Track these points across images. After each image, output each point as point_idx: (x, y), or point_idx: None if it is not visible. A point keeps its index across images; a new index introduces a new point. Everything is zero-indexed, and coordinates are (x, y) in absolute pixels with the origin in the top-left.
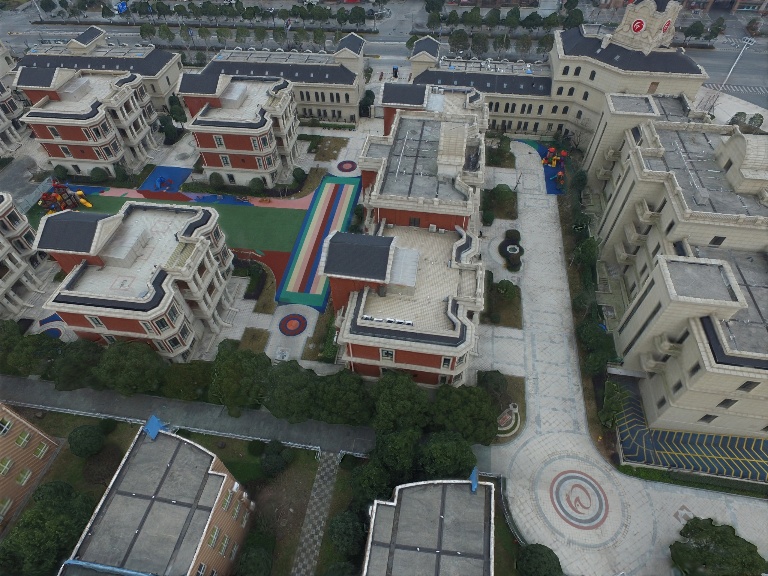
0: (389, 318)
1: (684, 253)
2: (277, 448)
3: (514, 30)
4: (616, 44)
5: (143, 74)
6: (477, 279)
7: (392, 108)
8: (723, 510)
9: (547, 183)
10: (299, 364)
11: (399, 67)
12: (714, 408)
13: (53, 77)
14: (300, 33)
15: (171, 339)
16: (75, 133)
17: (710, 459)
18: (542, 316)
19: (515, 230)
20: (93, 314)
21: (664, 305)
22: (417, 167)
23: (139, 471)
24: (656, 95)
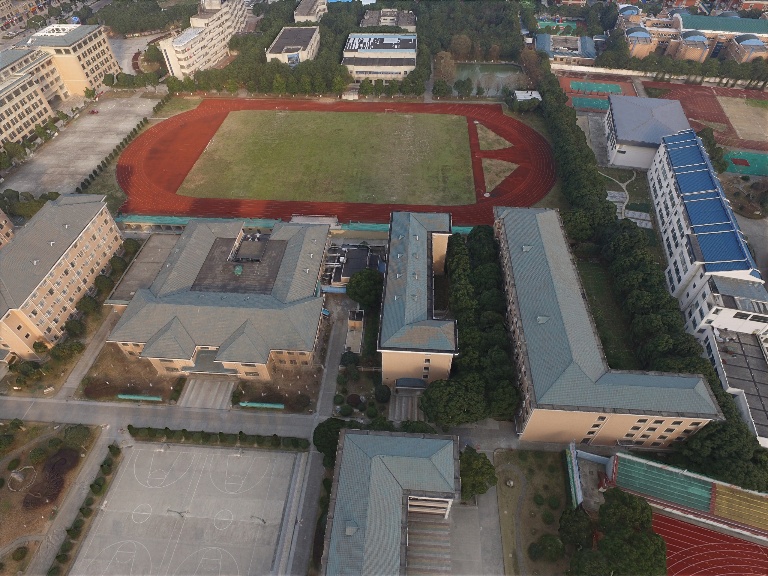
0: None
1: None
2: None
3: None
4: None
5: None
6: None
7: None
8: None
9: None
10: None
11: None
12: None
13: None
14: None
15: None
16: None
17: None
18: None
19: None
20: None
21: None
22: None
23: None
24: None
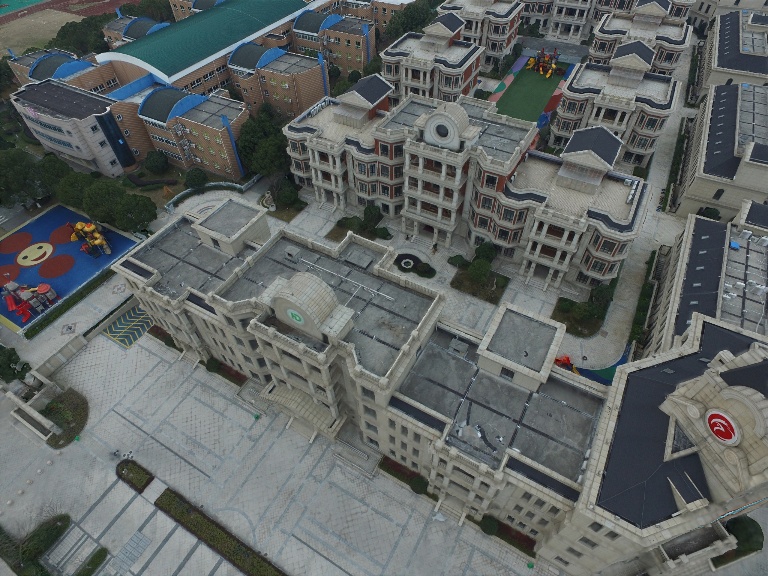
0: None
1: None
2: None
3: None
4: None
5: (720, 61)
6: None
7: None
8: None
9: None
10: None
11: None
12: None
13: (644, 4)
14: None
15: None
16: None
17: None
18: None
19: (425, 265)
20: None
21: None
22: None
23: (308, 62)
24: None
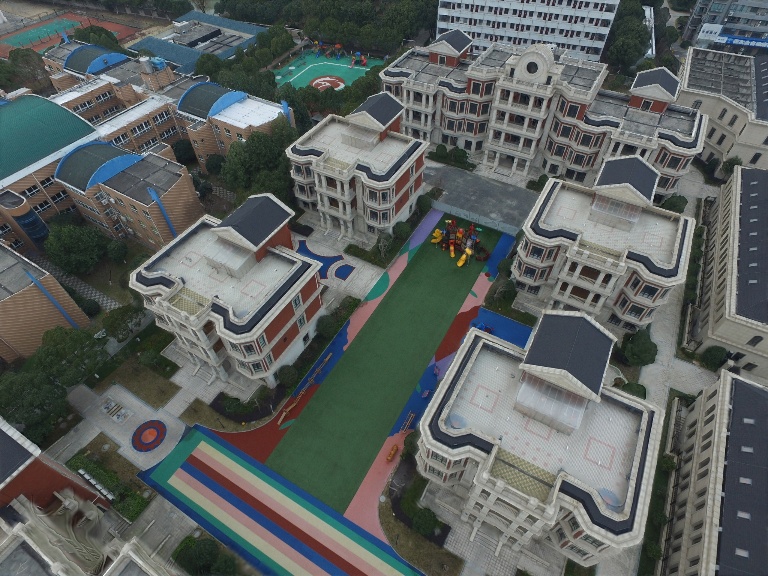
0: None
1: None
2: None
3: None
4: None
5: (740, 298)
6: None
7: None
8: None
9: None
10: (98, 429)
11: None
12: None
13: (611, 184)
14: None
15: None
16: None
17: None
18: None
19: None
20: None
21: None
22: None
23: (20, 272)
24: None
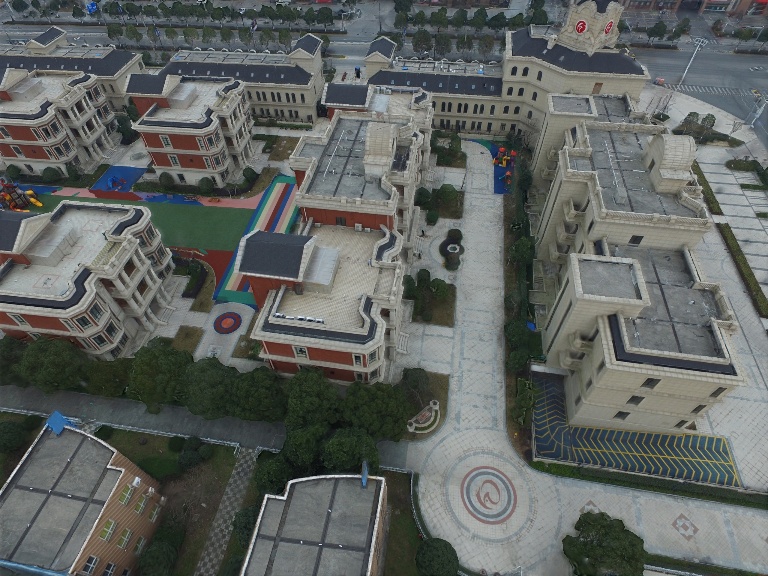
0: (301, 316)
1: (602, 252)
2: (195, 444)
3: (480, 30)
4: (561, 45)
5: (101, 74)
6: (395, 277)
7: (335, 108)
8: (629, 505)
9: (495, 183)
10: (229, 362)
11: (363, 67)
12: (624, 405)
13: (3, 77)
14: (265, 33)
15: (96, 337)
16: (25, 133)
17: (624, 455)
18: (474, 314)
19: (456, 229)
20: (14, 312)
21: (573, 303)
22: (347, 167)
23: (40, 466)
24: (601, 95)
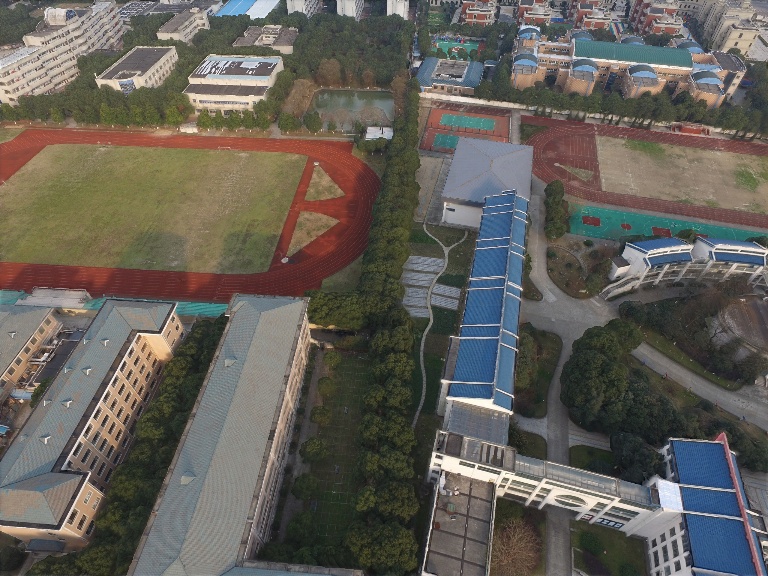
0: None
1: None
2: None
3: None
4: None
5: None
6: None
7: None
8: None
9: None
10: None
11: None
12: (733, 46)
13: None
14: None
15: None
16: (540, 0)
17: None
18: None
19: None
20: (595, 21)
21: None
22: None
23: None
24: None
